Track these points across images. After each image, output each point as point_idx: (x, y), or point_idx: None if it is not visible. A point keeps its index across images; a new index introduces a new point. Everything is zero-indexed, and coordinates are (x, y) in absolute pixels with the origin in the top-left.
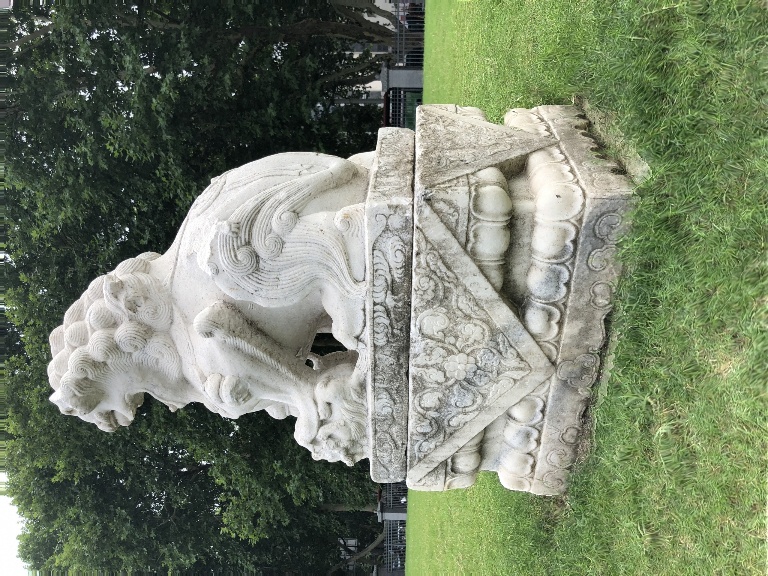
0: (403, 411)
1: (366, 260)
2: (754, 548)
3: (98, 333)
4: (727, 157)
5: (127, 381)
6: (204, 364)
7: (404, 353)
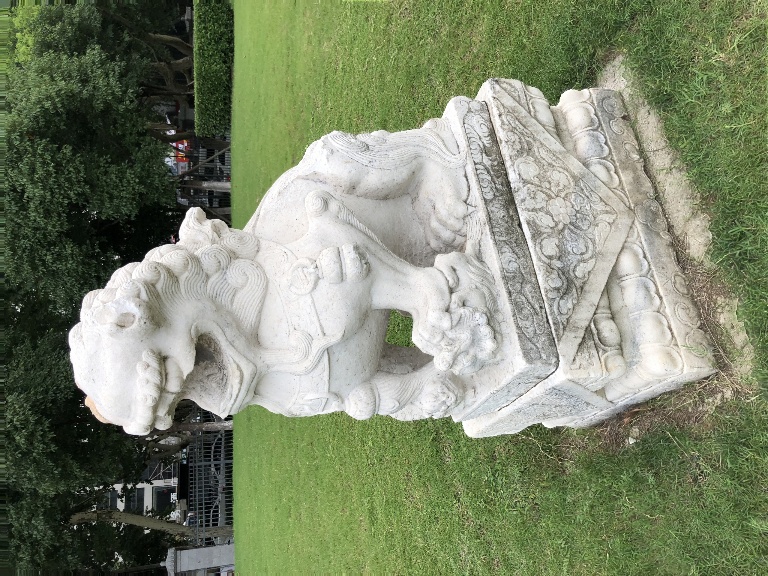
0: (529, 266)
1: (458, 138)
2: None
3: None
4: None
5: (199, 306)
6: (312, 248)
7: (511, 206)
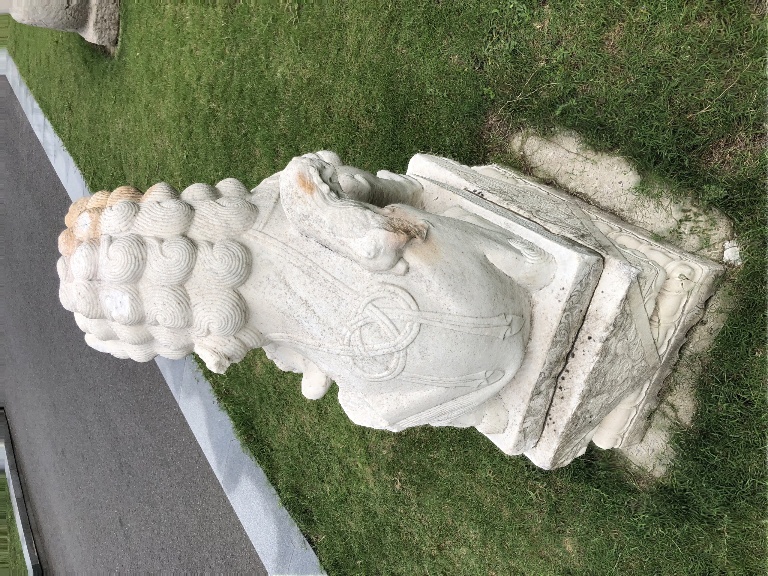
0: None
1: None
2: (524, 569)
3: (177, 354)
4: (648, 571)
5: None
6: None
7: None
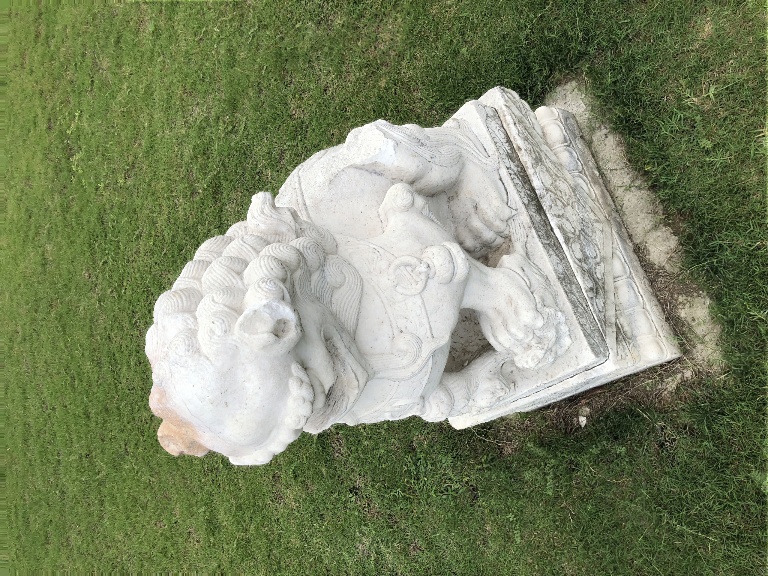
0: (569, 268)
1: (484, 141)
2: None
3: None
4: None
5: (319, 309)
6: (410, 246)
7: (541, 211)
